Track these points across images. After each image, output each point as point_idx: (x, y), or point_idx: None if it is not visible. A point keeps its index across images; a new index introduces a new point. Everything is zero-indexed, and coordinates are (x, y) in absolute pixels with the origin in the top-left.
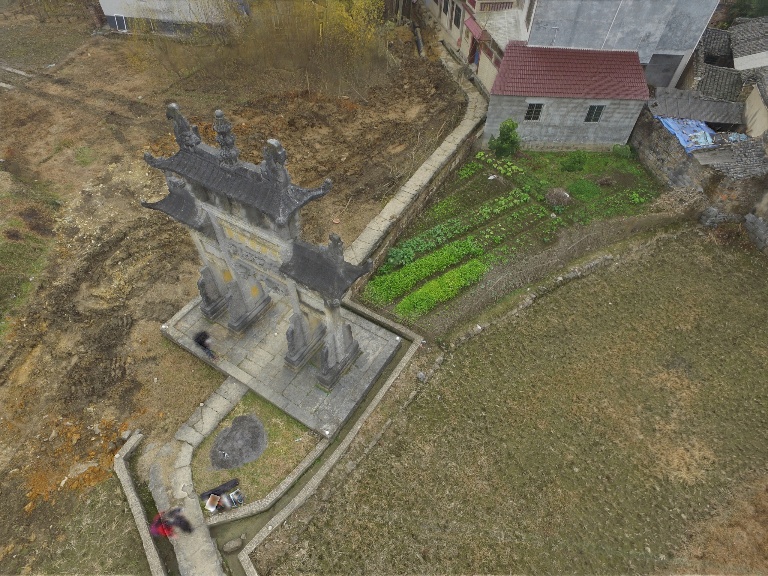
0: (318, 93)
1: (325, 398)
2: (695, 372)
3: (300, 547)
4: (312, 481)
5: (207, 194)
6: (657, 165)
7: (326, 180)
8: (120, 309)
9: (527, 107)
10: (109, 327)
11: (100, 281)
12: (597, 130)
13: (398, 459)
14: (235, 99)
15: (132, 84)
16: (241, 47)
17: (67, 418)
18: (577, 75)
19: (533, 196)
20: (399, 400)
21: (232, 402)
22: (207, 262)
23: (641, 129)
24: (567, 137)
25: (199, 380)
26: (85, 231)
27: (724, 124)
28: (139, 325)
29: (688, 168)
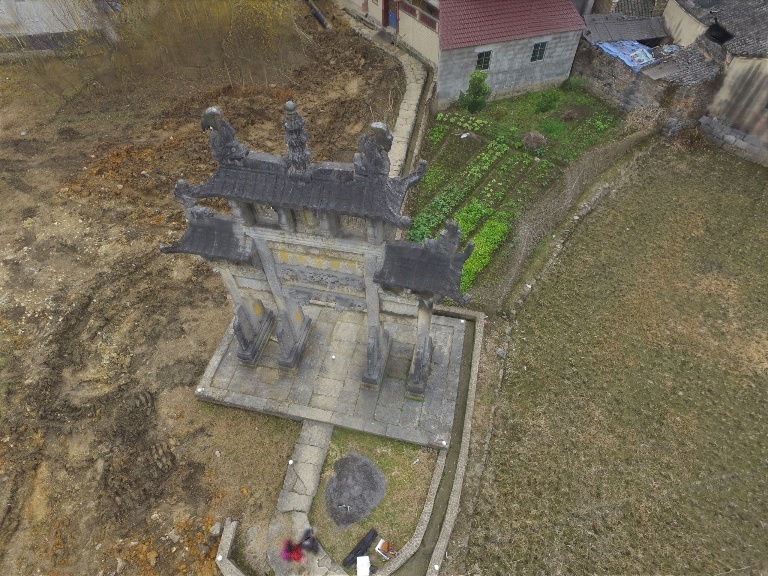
0: (241, 87)
1: (422, 408)
2: (727, 270)
3: (472, 574)
4: (452, 500)
5: (254, 216)
6: (605, 90)
7: (421, 162)
8: (129, 387)
9: (477, 57)
10: (126, 412)
11: (85, 362)
12: (542, 68)
13: (520, 444)
14: (146, 112)
15: (4, 120)
16: (133, 51)
17: (128, 538)
18: (515, 16)
19: (510, 145)
20: (492, 384)
21: (323, 447)
22: (240, 299)
23: (580, 59)
24: (516, 81)
25: (269, 436)
26: (33, 308)
27: (652, 39)
28: (163, 398)
29: (639, 86)
